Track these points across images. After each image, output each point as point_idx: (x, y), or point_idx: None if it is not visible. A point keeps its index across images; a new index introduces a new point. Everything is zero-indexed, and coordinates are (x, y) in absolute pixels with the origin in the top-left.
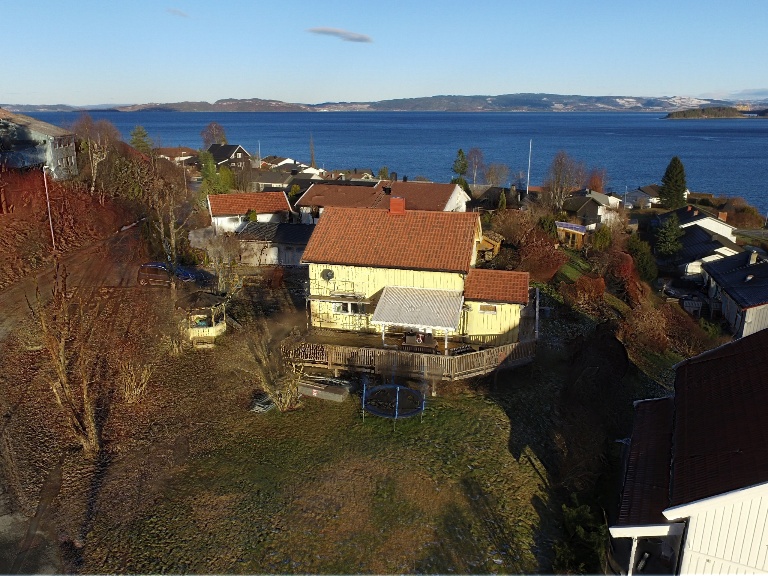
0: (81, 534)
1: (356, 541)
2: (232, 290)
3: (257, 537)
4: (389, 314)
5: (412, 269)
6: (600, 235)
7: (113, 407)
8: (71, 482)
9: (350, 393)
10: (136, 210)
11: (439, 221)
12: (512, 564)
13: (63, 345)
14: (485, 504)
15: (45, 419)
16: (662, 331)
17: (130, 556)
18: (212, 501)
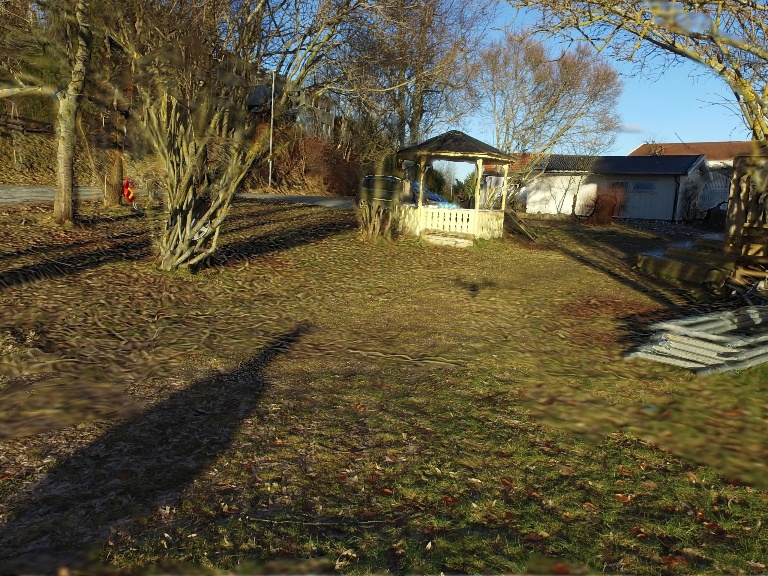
0: None
1: None
2: None
3: None
4: None
5: None
6: None
7: (106, 268)
8: None
9: None
10: None
11: None
12: None
13: (71, 107)
14: None
15: None
16: None
17: None
18: None
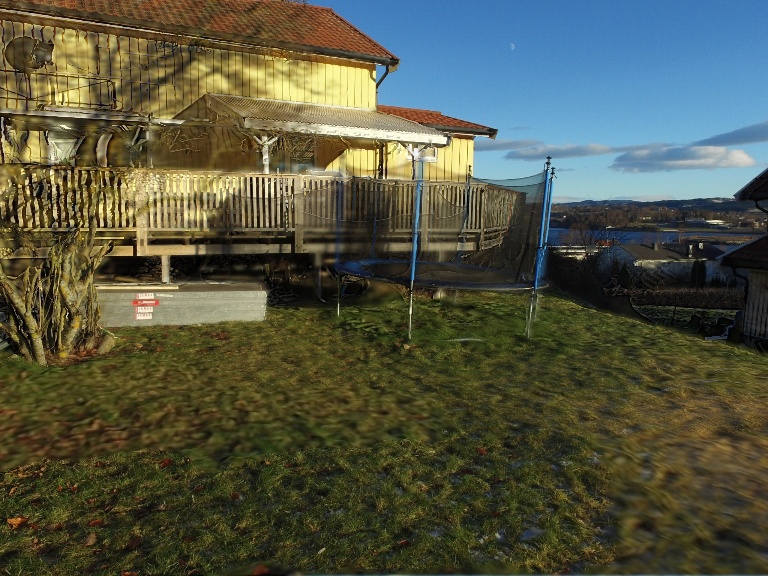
0: None
1: None
2: None
3: None
4: (276, 114)
5: (279, 43)
6: None
7: None
8: None
9: None
10: None
11: (268, 5)
12: None
13: None
14: None
15: None
16: None
17: None
18: None
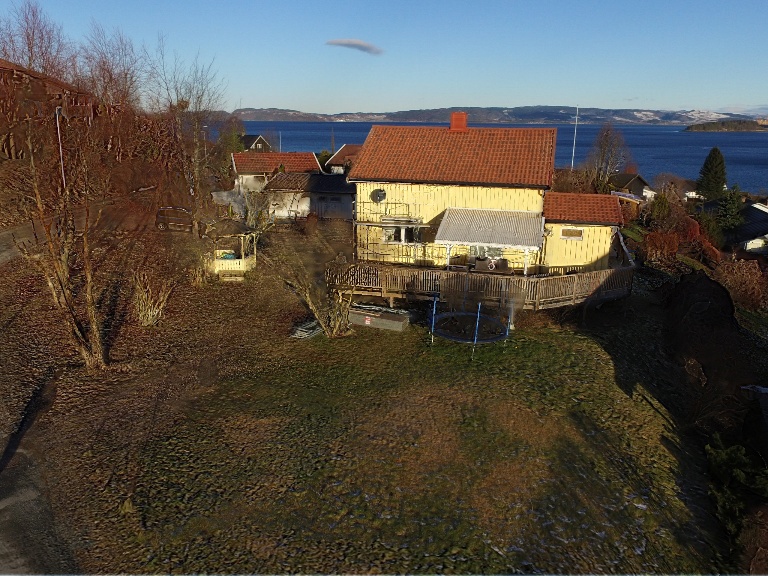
0: (76, 453)
1: (447, 473)
2: (263, 225)
3: (312, 464)
4: (456, 233)
5: (481, 184)
6: (658, 202)
7: (124, 329)
8: (67, 398)
9: (410, 323)
10: (155, 174)
11: (509, 137)
12: (660, 511)
13: (66, 257)
14: (605, 440)
15: (40, 336)
16: (756, 285)
17: (141, 480)
18: (249, 424)
